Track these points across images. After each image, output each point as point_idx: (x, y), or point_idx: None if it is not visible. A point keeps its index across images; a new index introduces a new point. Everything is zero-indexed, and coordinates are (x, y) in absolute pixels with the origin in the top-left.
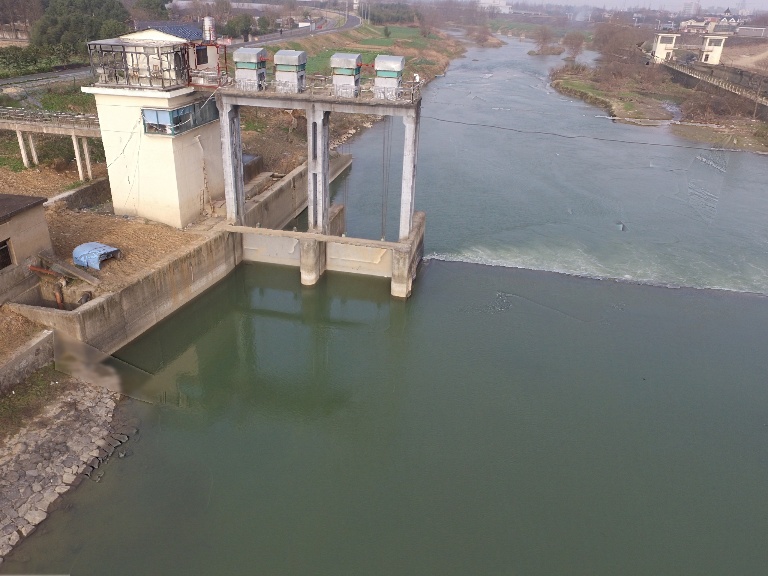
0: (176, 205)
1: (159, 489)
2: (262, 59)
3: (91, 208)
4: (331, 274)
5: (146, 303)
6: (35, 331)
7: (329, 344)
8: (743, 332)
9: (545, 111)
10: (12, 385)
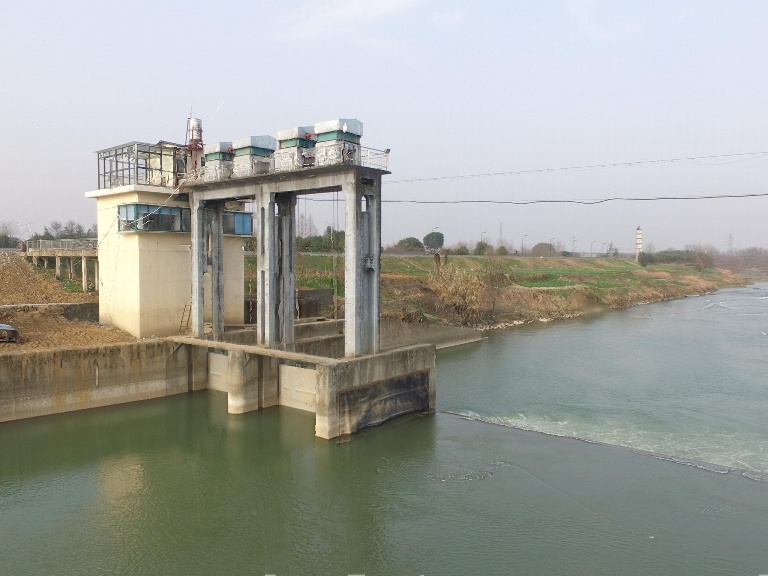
0: (137, 310)
1: None
2: (230, 150)
3: None
4: (285, 411)
5: (1, 389)
6: None
7: (289, 521)
8: None
9: None
10: None
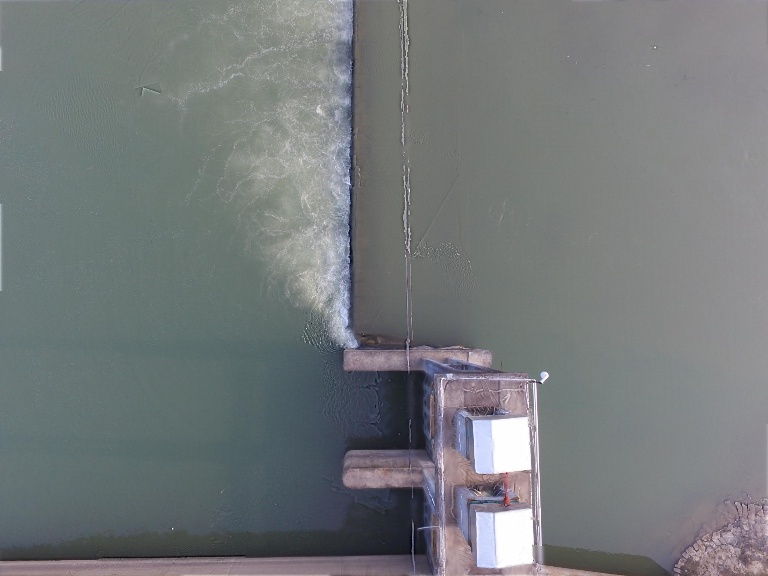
0: None
1: (759, 458)
2: None
3: None
4: None
5: None
6: None
7: None
8: (438, 37)
9: None
10: None
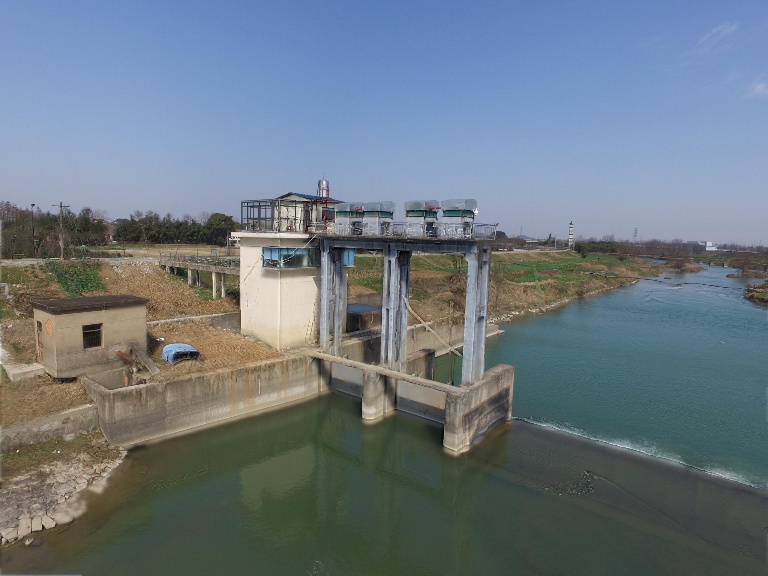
0: (277, 329)
1: None
2: (356, 209)
3: (232, 329)
4: (400, 414)
5: (196, 402)
6: (81, 403)
7: (398, 493)
8: None
9: (728, 313)
10: (23, 444)
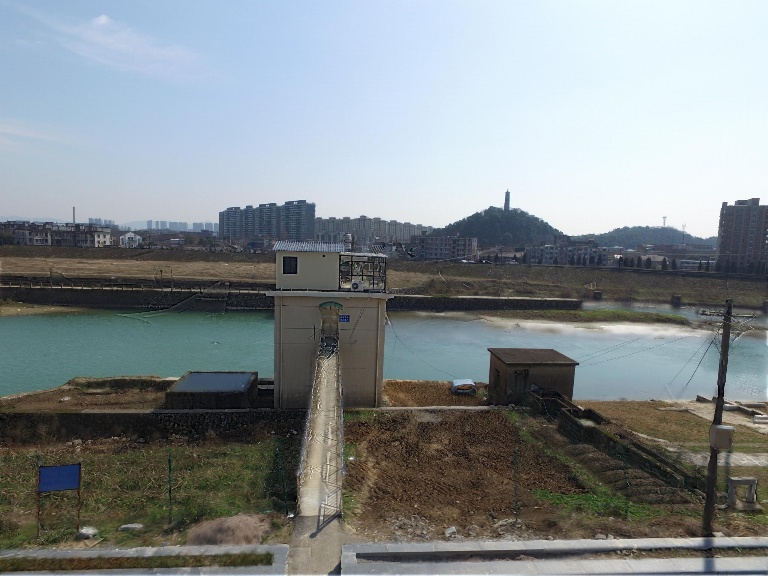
0: None
1: None
2: None
3: None
4: None
5: None
6: None
7: None
8: None
9: None
10: None
